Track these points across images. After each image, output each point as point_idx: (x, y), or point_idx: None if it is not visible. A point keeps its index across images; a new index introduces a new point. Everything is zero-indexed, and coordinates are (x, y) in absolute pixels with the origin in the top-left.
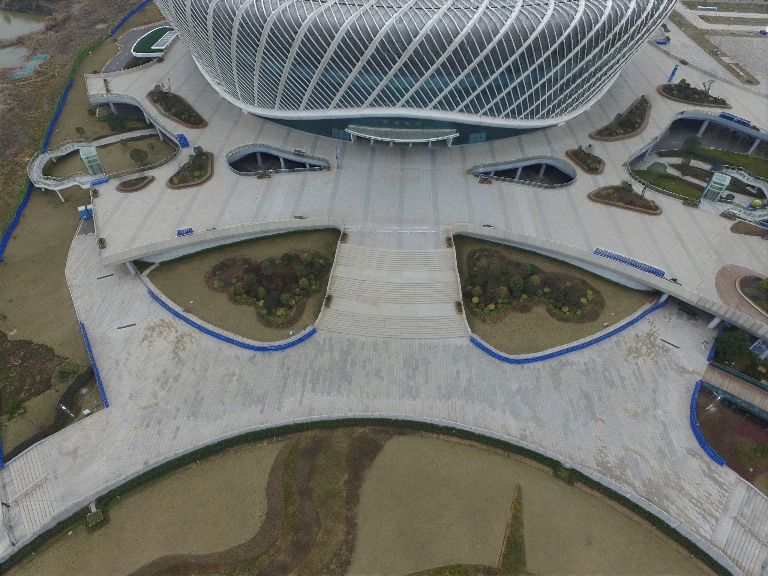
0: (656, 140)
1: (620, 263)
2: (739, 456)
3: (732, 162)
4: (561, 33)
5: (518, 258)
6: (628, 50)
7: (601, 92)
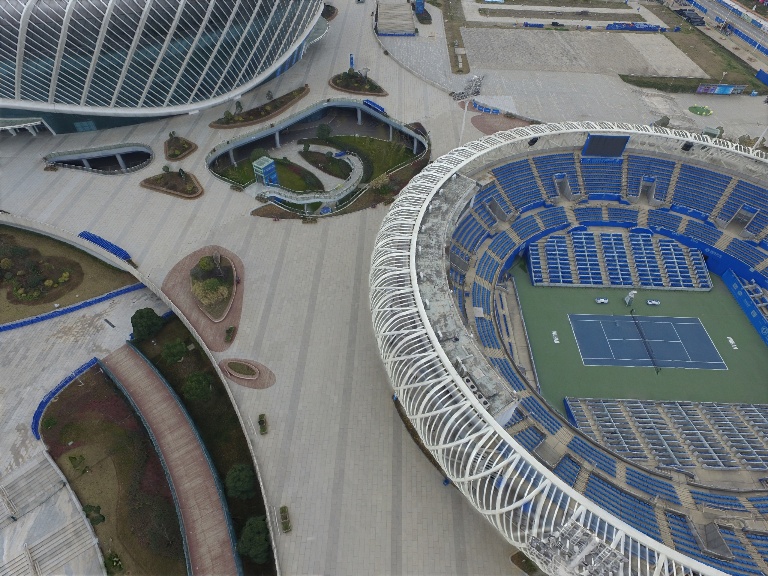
0: (274, 127)
1: (95, 245)
2: (66, 430)
3: (362, 148)
4: (60, 18)
5: (27, 243)
6: (211, 37)
7: (252, 81)
